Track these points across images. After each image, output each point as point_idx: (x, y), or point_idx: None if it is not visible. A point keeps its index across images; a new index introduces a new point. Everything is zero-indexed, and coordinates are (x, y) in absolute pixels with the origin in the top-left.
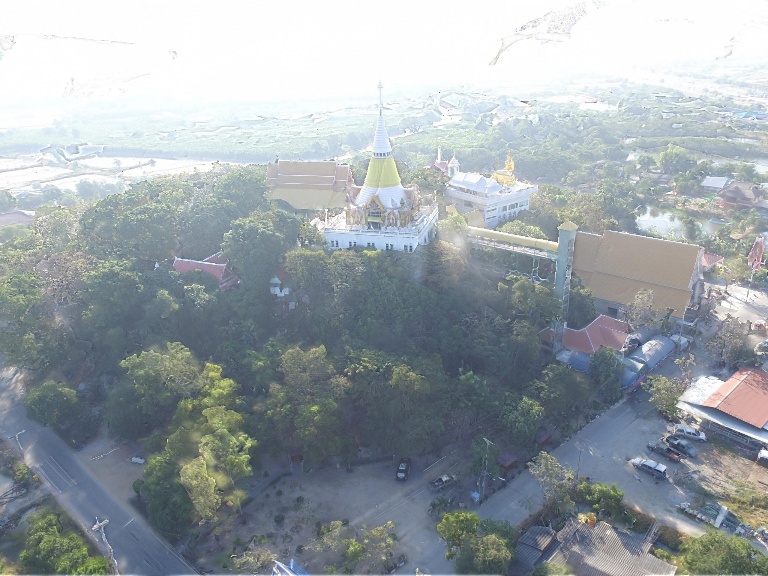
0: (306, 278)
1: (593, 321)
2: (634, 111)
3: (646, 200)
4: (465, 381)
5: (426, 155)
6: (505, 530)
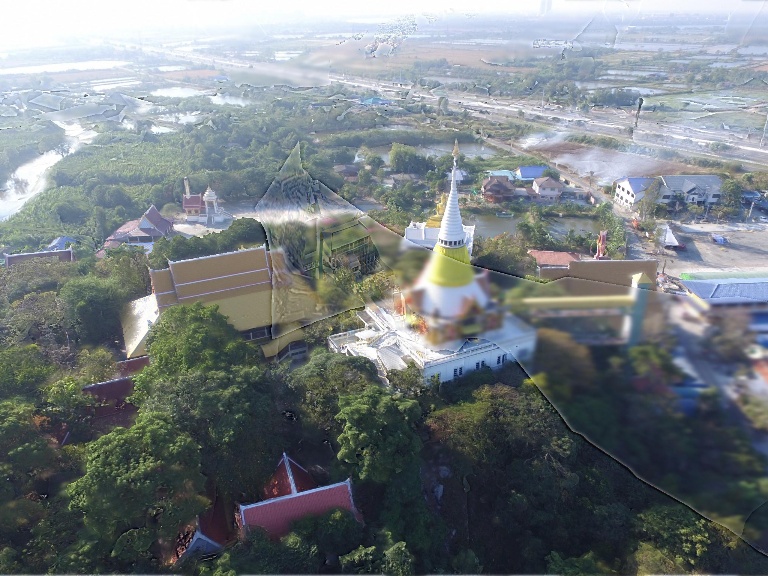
0: (486, 450)
1: None
2: (283, 105)
3: (425, 204)
4: None
5: (134, 186)
6: None
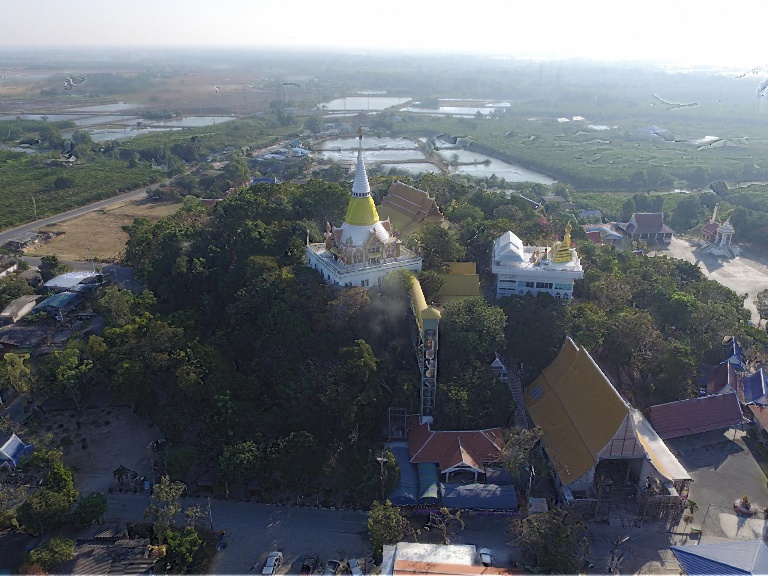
0: None
1: (457, 430)
2: None
3: None
4: None
5: None
6: (86, 504)
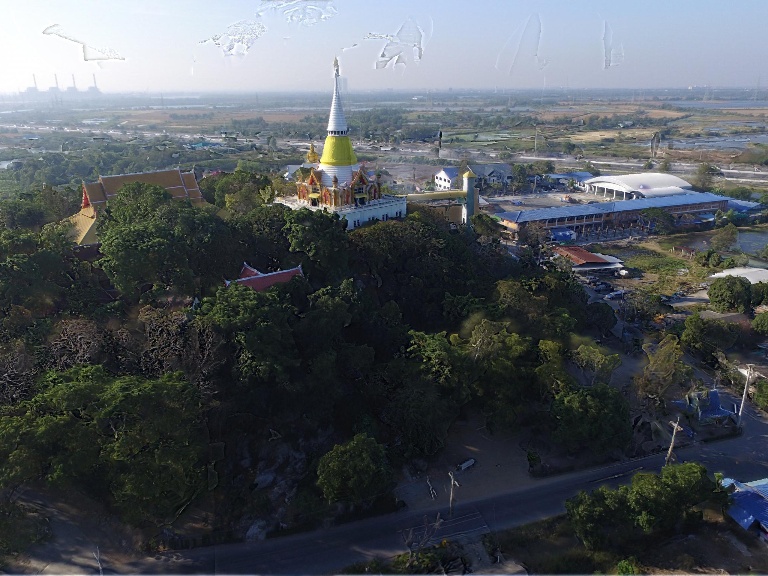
0: (389, 251)
1: None
2: (112, 149)
3: None
4: (560, 275)
5: None
6: None
